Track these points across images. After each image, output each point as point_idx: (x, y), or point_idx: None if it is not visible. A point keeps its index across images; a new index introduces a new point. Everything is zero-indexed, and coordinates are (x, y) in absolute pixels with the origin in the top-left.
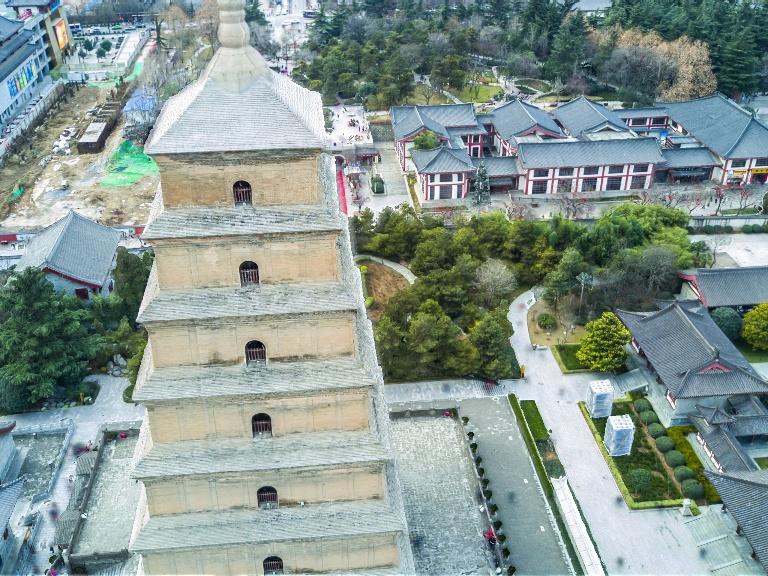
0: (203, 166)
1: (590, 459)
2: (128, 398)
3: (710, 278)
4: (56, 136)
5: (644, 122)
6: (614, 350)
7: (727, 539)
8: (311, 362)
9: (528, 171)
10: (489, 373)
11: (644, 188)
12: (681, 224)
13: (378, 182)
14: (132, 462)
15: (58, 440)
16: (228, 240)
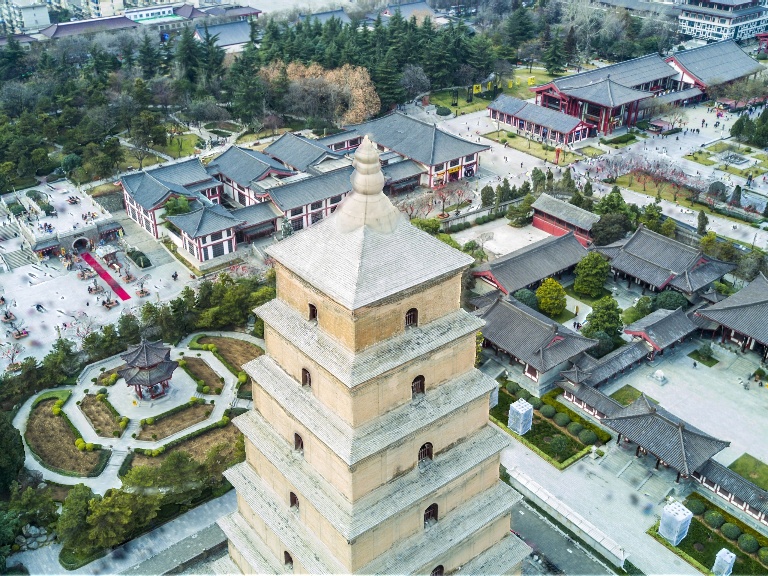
0: (387, 305)
1: None
2: (72, 565)
3: (500, 270)
4: None
5: (343, 145)
6: None
7: (634, 464)
8: (462, 444)
9: (286, 212)
10: None
11: None
12: (436, 230)
13: (142, 256)
14: None
15: None
16: (409, 363)
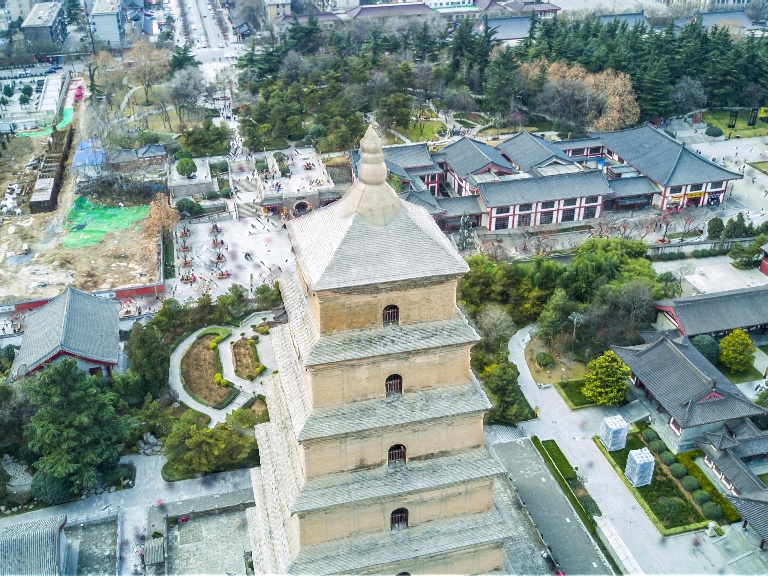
0: (359, 295)
1: (617, 492)
2: (169, 477)
3: (685, 308)
4: (0, 194)
5: (582, 152)
6: (618, 385)
7: (753, 555)
8: (445, 457)
9: (491, 209)
10: (510, 418)
11: (595, 217)
12: (641, 254)
13: None
14: (280, 566)
15: (107, 528)
16: (379, 359)
